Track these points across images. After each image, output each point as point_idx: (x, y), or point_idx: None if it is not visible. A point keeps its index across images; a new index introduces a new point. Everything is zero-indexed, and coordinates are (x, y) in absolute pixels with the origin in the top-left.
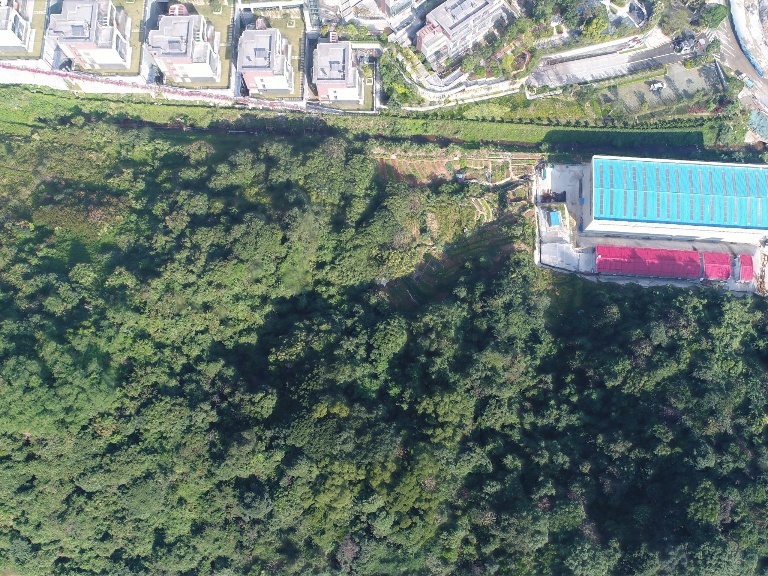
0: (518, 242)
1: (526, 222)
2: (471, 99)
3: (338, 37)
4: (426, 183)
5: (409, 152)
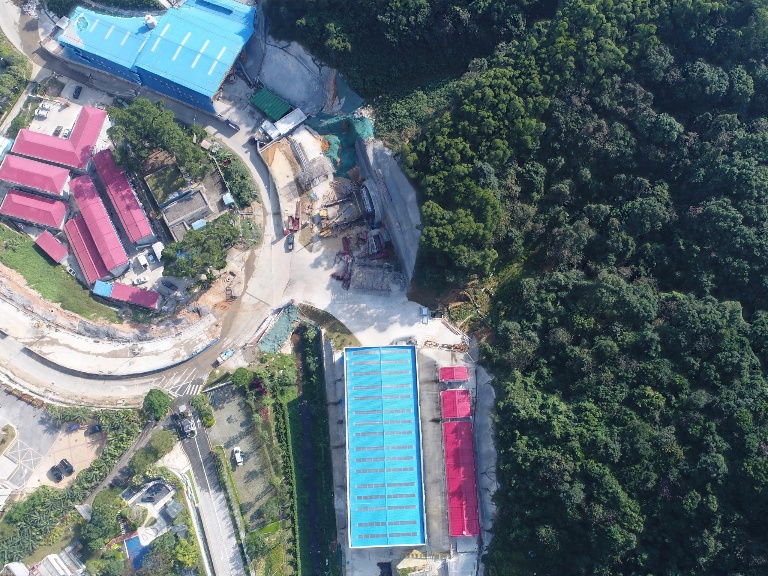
0: None
1: None
2: None
3: None
4: None
5: None
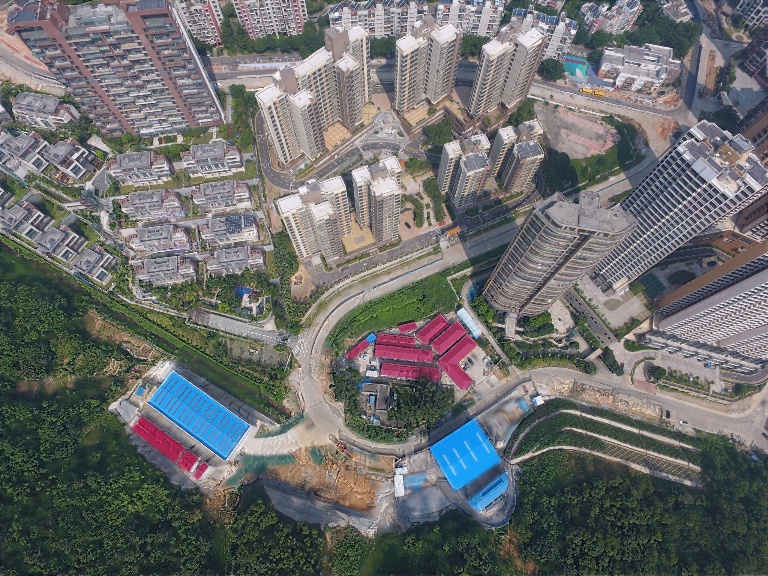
0: (109, 393)
1: (127, 385)
2: (158, 309)
3: (106, 249)
4: (104, 339)
5: (107, 320)
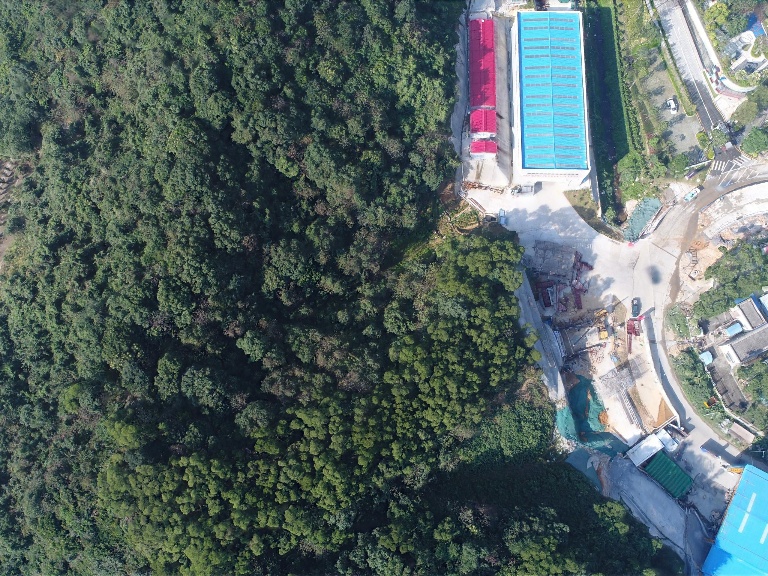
0: None
1: None
2: None
3: None
4: None
5: None
